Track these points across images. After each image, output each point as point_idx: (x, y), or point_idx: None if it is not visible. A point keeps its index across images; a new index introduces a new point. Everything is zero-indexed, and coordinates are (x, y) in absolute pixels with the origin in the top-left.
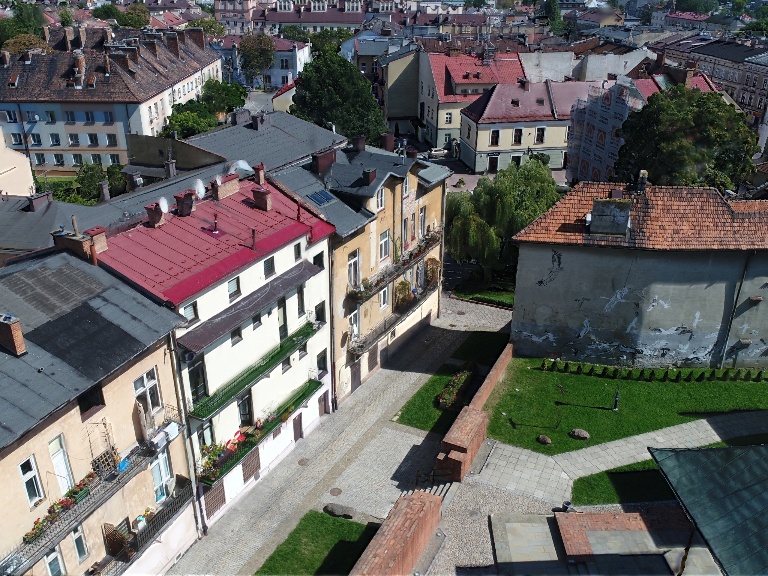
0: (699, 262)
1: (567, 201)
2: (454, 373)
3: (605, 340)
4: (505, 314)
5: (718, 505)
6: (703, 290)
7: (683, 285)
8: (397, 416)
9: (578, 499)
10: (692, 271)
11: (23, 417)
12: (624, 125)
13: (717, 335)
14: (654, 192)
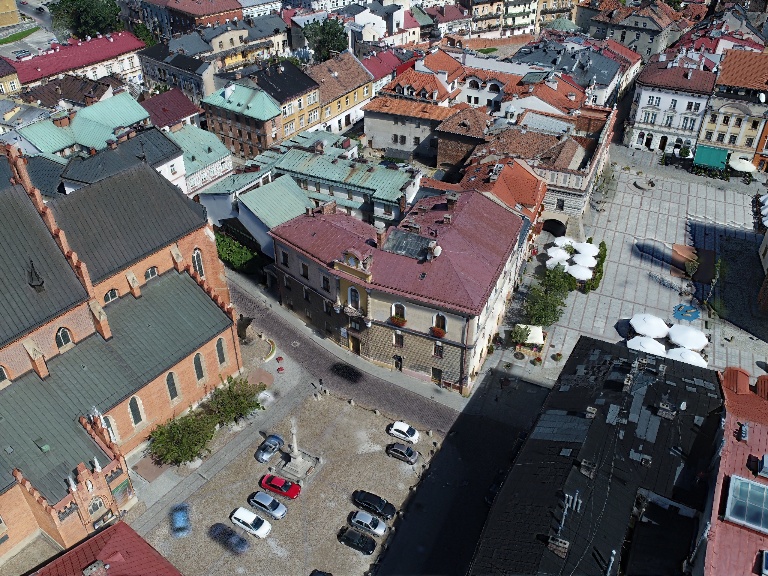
0: None
1: None
2: None
3: None
4: None
5: None
6: None
7: None
8: None
9: None
10: None
11: (485, 0)
12: None
13: None
14: None
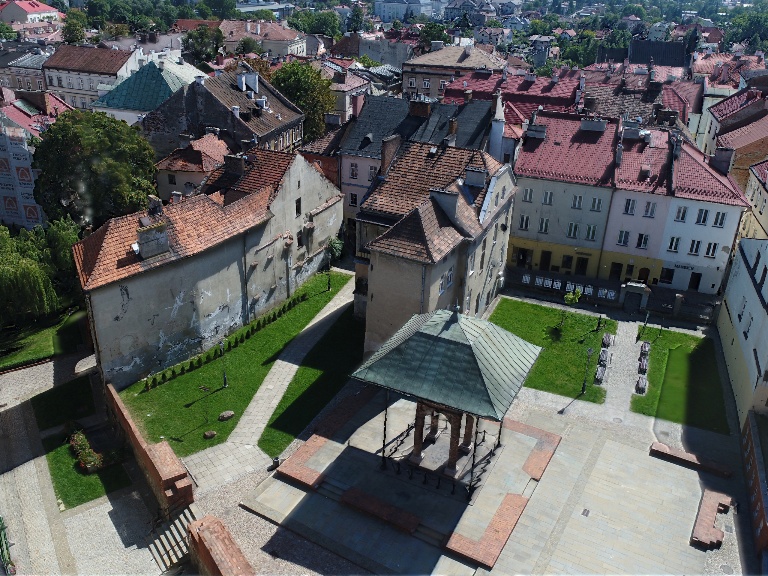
0: (220, 252)
1: (110, 240)
2: (64, 440)
3: (178, 341)
4: (41, 370)
5: (416, 379)
6: (227, 272)
7: (215, 274)
8: (61, 505)
9: (273, 453)
10: (217, 261)
11: None
12: (36, 156)
13: (241, 301)
14: (170, 210)
